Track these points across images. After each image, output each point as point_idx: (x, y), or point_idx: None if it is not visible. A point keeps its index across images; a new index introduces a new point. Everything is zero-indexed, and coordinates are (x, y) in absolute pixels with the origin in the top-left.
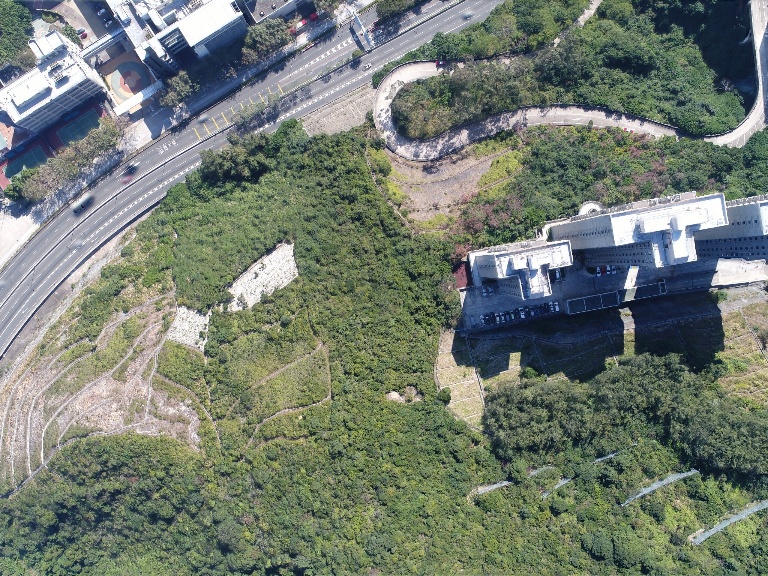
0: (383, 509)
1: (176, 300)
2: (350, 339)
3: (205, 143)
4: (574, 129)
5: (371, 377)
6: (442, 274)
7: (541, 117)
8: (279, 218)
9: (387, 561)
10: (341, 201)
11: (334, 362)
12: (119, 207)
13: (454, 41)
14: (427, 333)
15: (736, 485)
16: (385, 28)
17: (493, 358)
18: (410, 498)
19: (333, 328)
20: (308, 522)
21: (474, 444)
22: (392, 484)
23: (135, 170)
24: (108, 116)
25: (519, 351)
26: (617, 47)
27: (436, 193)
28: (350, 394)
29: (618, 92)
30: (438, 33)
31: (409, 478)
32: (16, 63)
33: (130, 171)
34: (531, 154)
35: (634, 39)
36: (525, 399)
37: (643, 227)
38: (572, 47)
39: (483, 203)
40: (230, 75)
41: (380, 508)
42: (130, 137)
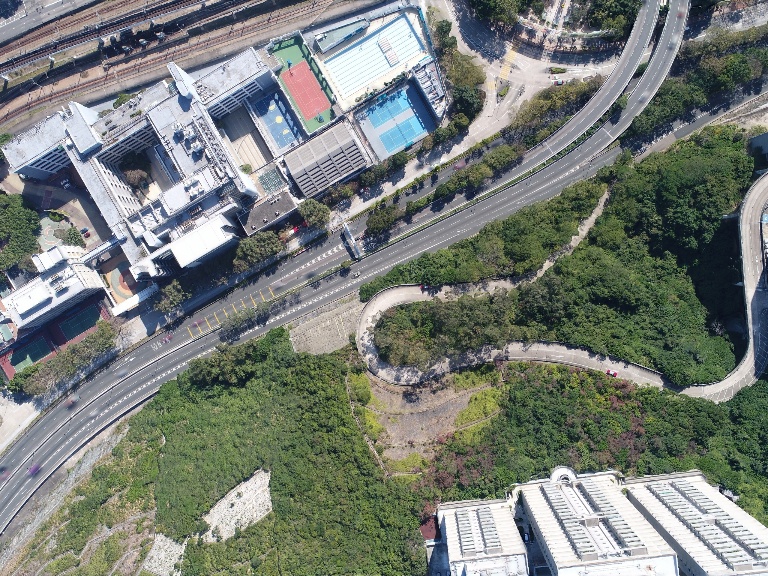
0: None
1: (155, 525)
2: None
3: (197, 342)
4: (556, 368)
5: None
6: (410, 529)
7: (523, 351)
8: (258, 443)
9: None
10: (319, 428)
11: None
12: (114, 399)
13: (441, 262)
14: None
15: None
16: (376, 236)
17: None
18: None
19: None
20: None
21: None
22: None
23: (130, 365)
24: (105, 320)
25: None
26: (604, 284)
27: (413, 427)
28: None
29: (603, 331)
30: (425, 254)
31: None
32: (22, 266)
33: (125, 365)
34: (509, 398)
35: (622, 275)
36: None
37: None
38: (555, 289)
39: (456, 450)
40: (222, 283)
41: None
42: (127, 333)
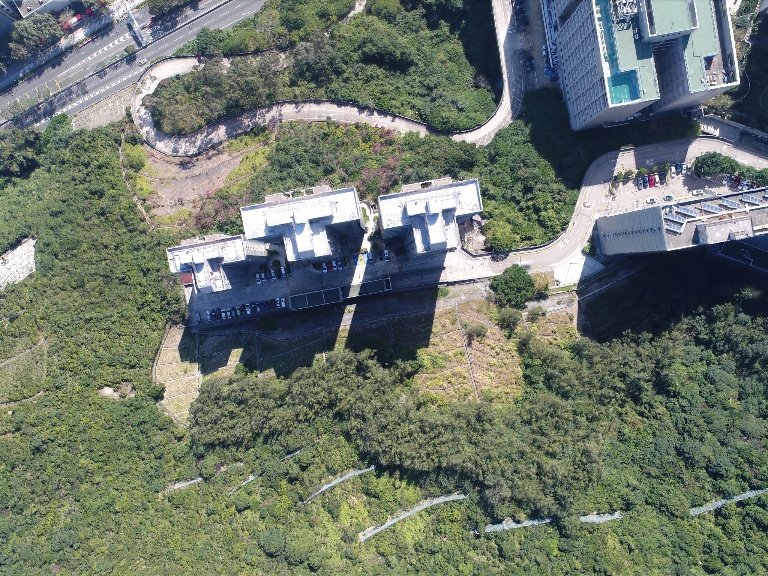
0: (77, 505)
1: None
2: (70, 334)
3: None
4: (326, 125)
5: (84, 372)
6: None
7: (296, 113)
8: (28, 213)
9: (69, 557)
10: (91, 196)
11: (51, 357)
12: None
13: (219, 37)
14: (152, 329)
15: (411, 482)
16: (163, 24)
17: (216, 354)
18: (102, 494)
19: (55, 323)
20: (5, 518)
21: (177, 440)
22: (86, 480)
23: None
24: None
25: (242, 347)
26: (372, 43)
27: (185, 189)
28: (62, 389)
29: (372, 88)
30: (203, 28)
31: (105, 474)
32: None
33: None
34: (275, 150)
35: (390, 35)
36: (222, 395)
37: (266, 220)
38: (320, 42)
39: None
40: None
41: (75, 504)
42: None
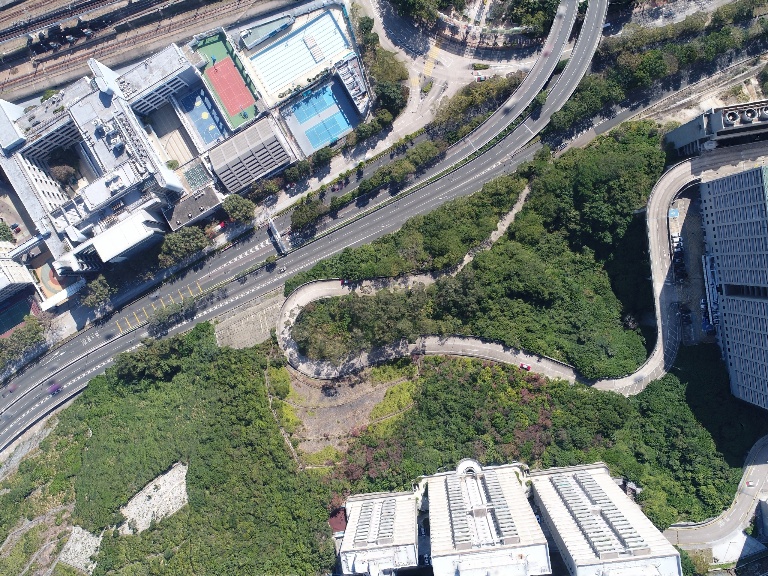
0: None
1: (73, 517)
2: None
3: (126, 336)
4: (470, 362)
5: None
6: (319, 521)
7: (439, 345)
8: (178, 436)
9: None
10: (238, 422)
11: None
12: (45, 393)
13: (362, 257)
14: None
15: None
16: (302, 231)
17: None
18: None
19: (210, 569)
20: None
21: None
22: None
23: (60, 359)
24: (32, 315)
25: None
26: (519, 278)
27: (329, 421)
28: None
29: (517, 325)
30: (346, 249)
31: None
32: None
33: (55, 360)
34: (422, 391)
35: (537, 270)
36: None
37: None
38: (469, 283)
39: (368, 443)
40: (148, 278)
41: None
42: (57, 327)
